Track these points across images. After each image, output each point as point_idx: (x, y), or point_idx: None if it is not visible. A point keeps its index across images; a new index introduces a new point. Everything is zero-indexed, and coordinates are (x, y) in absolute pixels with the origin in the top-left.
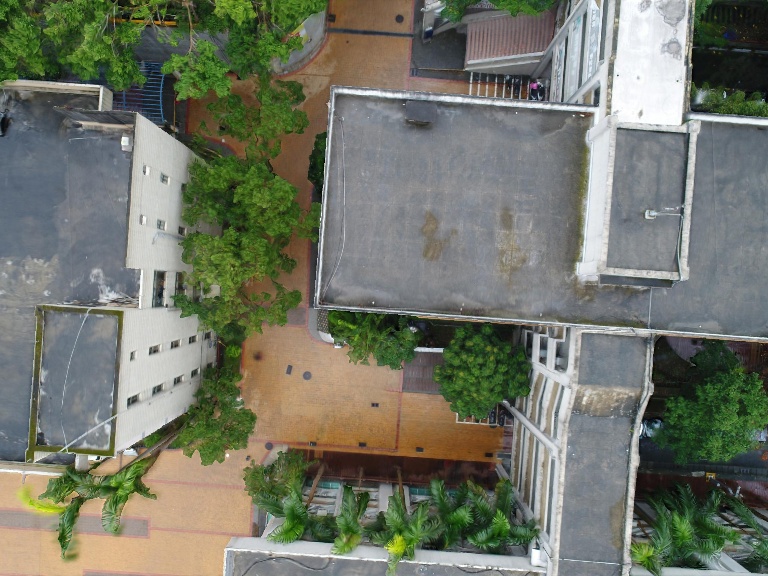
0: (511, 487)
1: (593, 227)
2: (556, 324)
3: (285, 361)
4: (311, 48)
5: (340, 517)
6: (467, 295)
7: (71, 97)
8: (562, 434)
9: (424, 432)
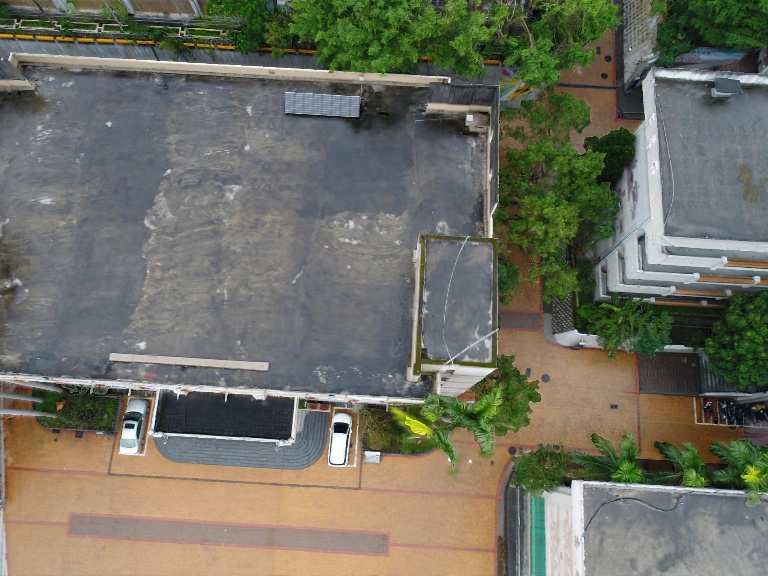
0: None
1: None
2: None
3: (524, 364)
4: (534, 97)
5: (686, 451)
6: None
7: (416, 90)
8: None
9: (665, 434)
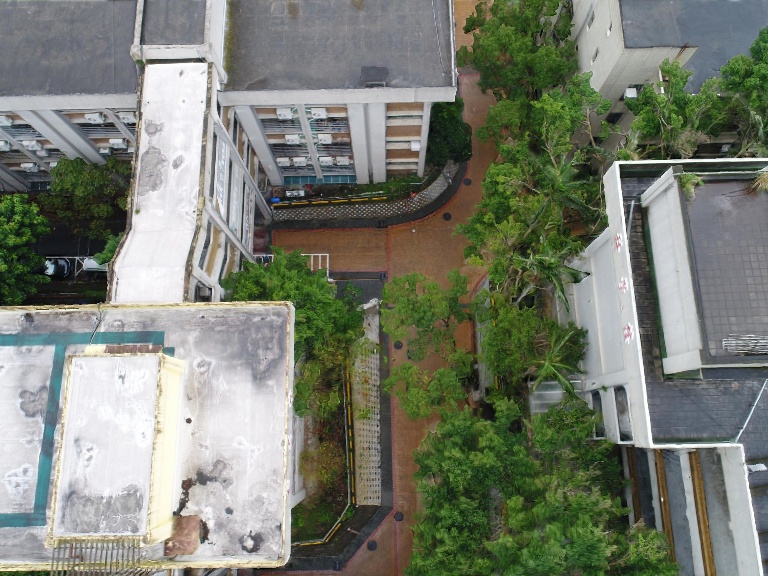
0: None
1: None
2: None
3: None
4: None
5: None
6: None
7: None
8: None
9: None
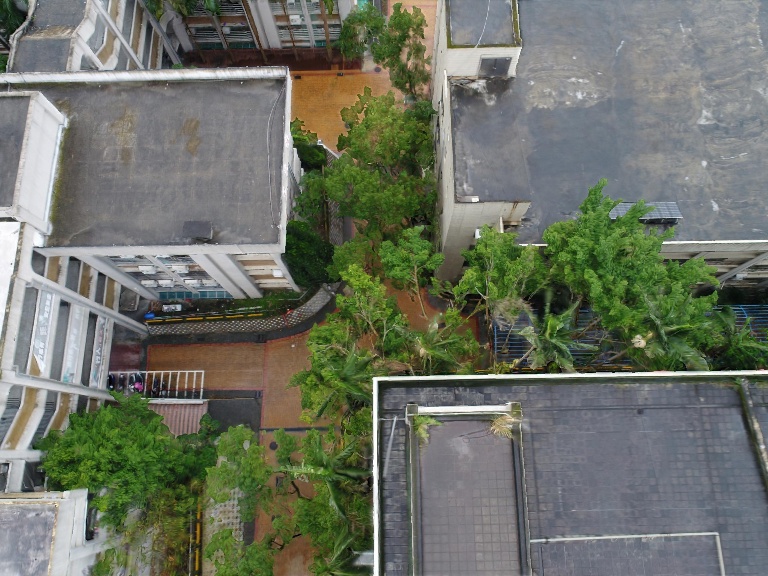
0: (148, 5)
1: (46, 144)
2: (84, 72)
3: None
4: None
5: None
6: (162, 96)
7: None
8: (90, 10)
9: None
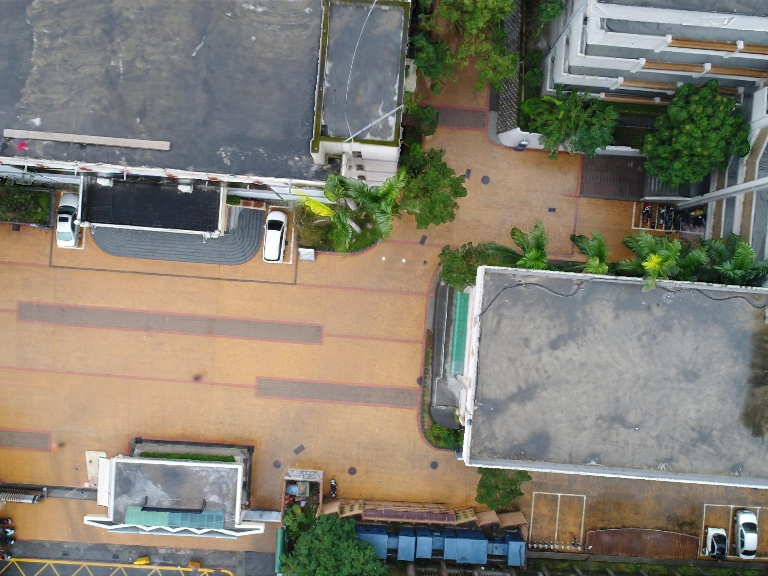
0: (738, 237)
1: None
2: None
3: (464, 165)
4: None
5: (593, 240)
6: (739, 1)
7: None
8: None
9: None
